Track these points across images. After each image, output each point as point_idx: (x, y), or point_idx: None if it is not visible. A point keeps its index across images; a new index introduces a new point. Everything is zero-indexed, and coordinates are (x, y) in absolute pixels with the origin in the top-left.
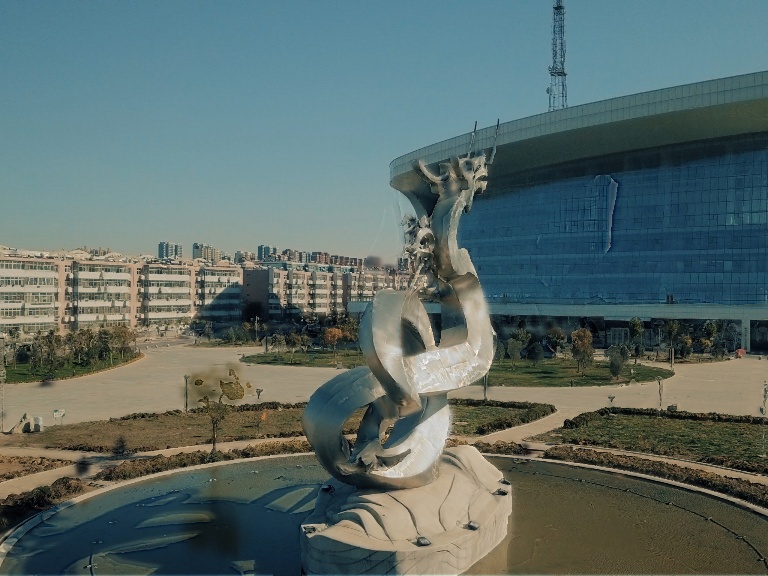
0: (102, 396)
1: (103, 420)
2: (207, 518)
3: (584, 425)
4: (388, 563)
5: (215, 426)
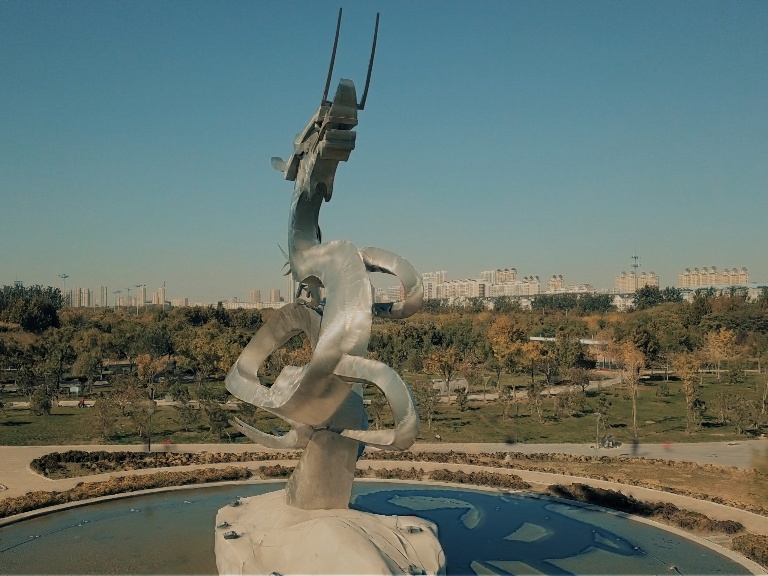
0: None
1: None
2: (514, 539)
3: None
4: None
5: None
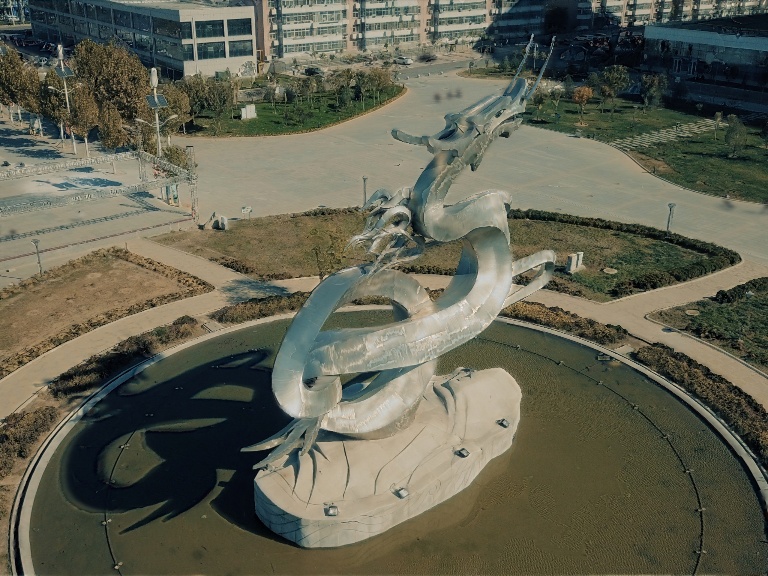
0: (319, 168)
1: (289, 213)
2: (251, 396)
3: (742, 298)
4: (296, 524)
5: (321, 277)
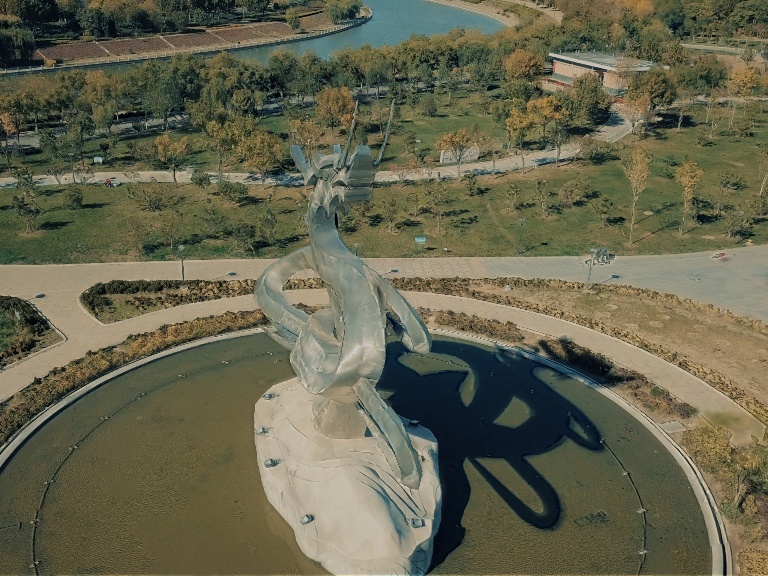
0: None
1: None
2: (502, 424)
3: None
4: None
5: None
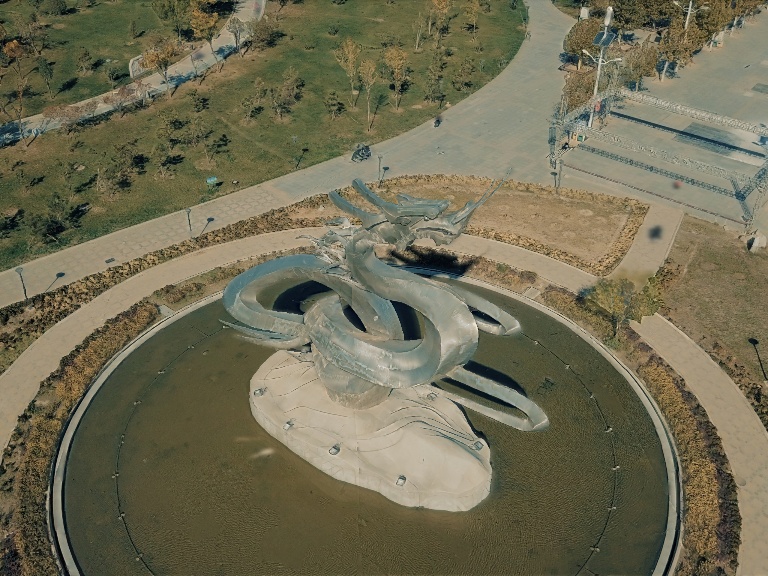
0: None
1: None
2: None
3: None
4: None
5: None
